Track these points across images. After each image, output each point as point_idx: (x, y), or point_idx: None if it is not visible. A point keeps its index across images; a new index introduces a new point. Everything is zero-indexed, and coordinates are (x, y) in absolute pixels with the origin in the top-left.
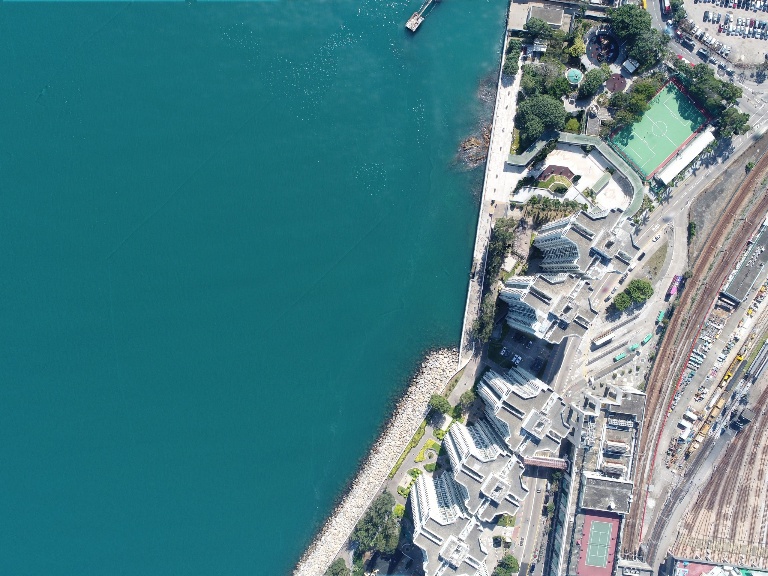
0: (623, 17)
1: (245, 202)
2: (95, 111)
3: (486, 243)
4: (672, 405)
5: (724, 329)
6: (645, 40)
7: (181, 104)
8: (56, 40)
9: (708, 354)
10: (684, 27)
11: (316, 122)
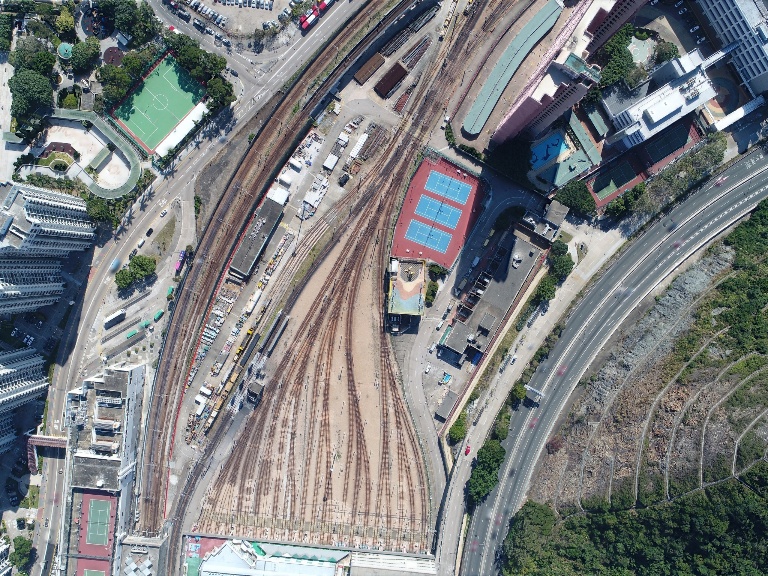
0: None
1: None
2: None
3: None
4: (188, 381)
5: (236, 303)
6: (122, 11)
7: None
8: None
9: (222, 329)
10: None
11: None
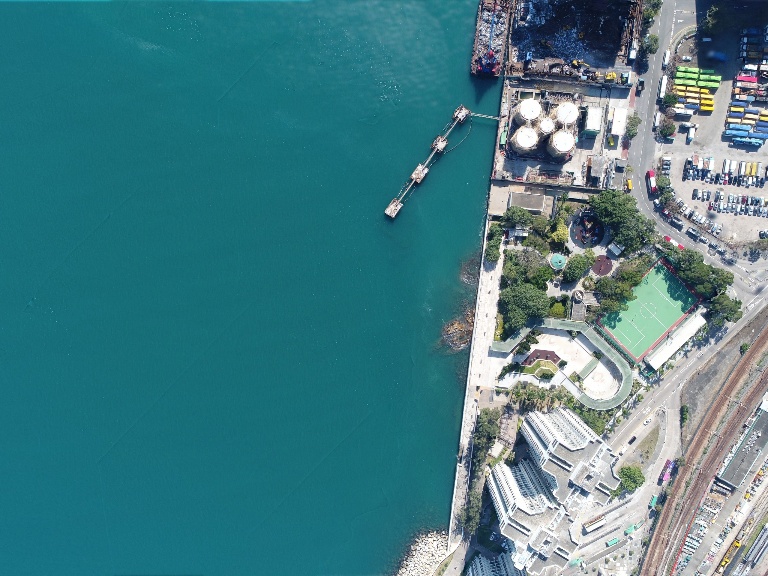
0: (606, 205)
1: (228, 404)
2: (80, 321)
3: (472, 428)
4: None
5: (720, 513)
6: (629, 228)
7: (163, 310)
8: (40, 253)
9: (704, 538)
10: (671, 209)
11: (295, 326)
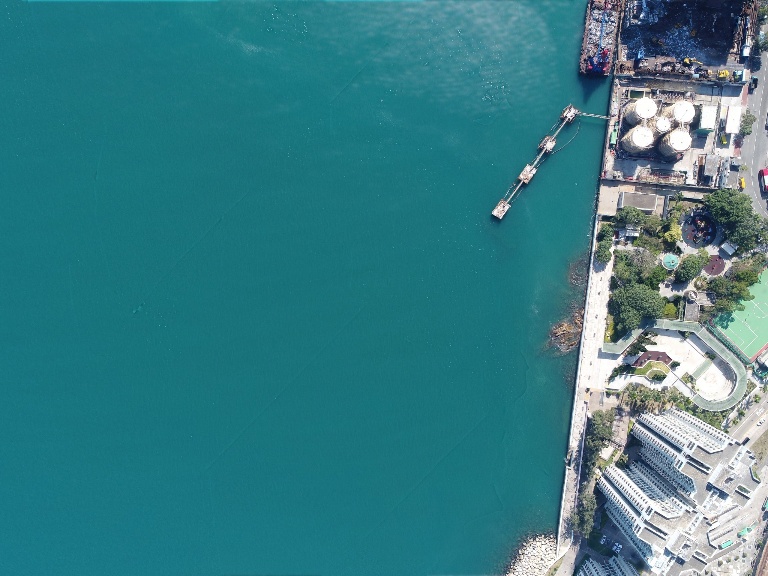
0: (722, 204)
1: (340, 409)
2: (190, 326)
3: (582, 431)
4: None
5: None
6: (747, 227)
7: (273, 314)
8: (149, 258)
9: None
10: None
11: (409, 329)
